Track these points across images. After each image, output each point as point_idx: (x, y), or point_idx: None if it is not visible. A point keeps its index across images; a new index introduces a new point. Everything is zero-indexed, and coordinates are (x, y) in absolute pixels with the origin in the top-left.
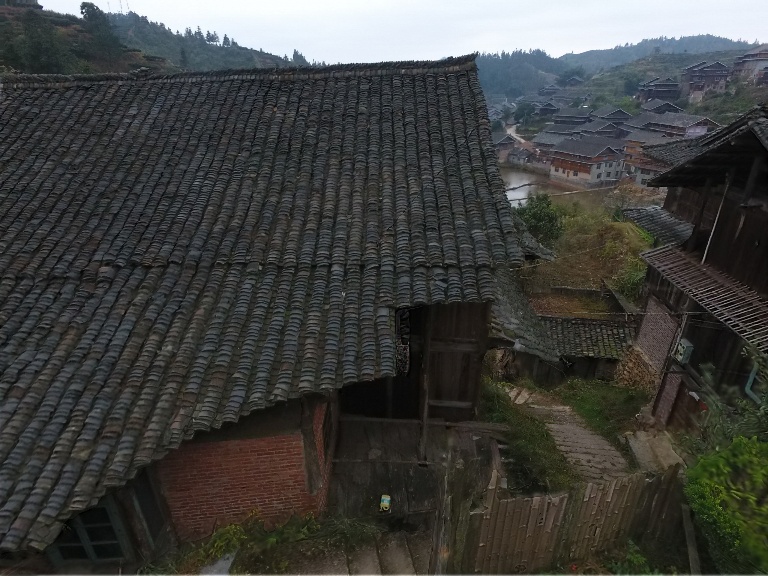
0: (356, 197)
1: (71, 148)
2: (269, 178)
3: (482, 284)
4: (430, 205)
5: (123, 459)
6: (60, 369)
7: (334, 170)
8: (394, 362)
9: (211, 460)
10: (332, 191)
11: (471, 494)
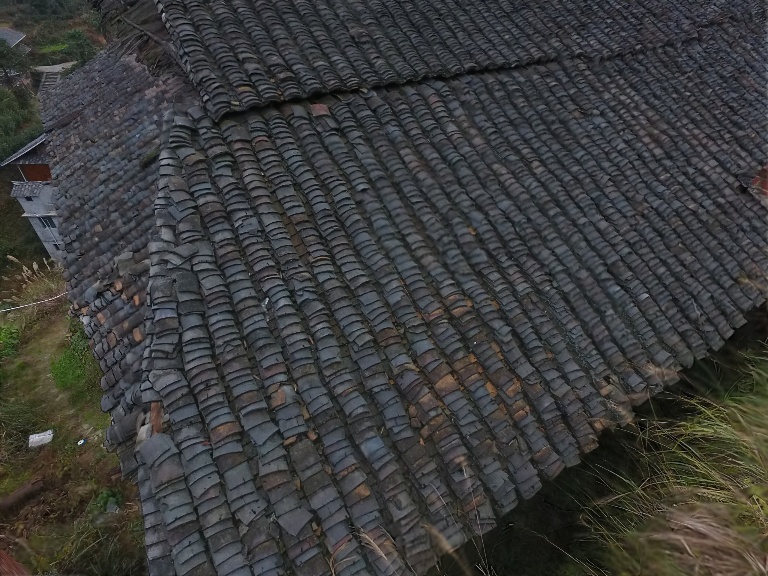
0: None
1: None
2: None
3: None
4: None
5: None
6: None
7: None
8: None
9: None
10: None
11: None
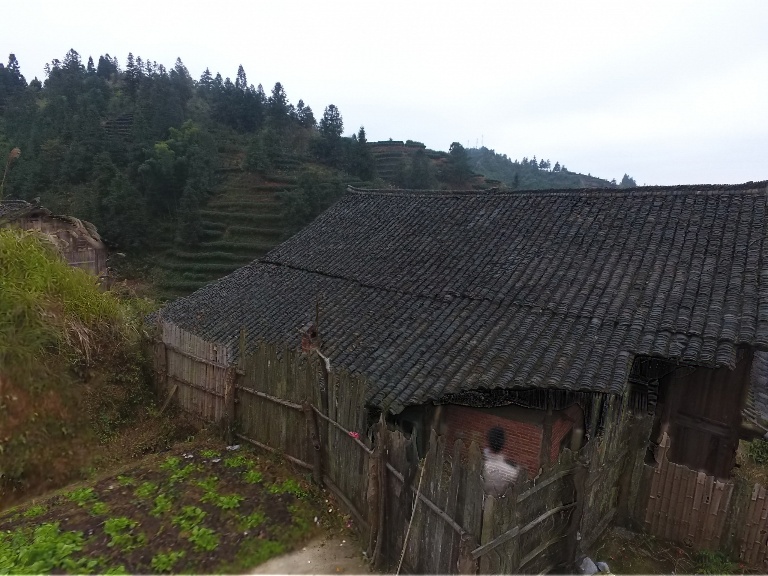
0: (626, 279)
1: (443, 231)
2: (562, 259)
3: (720, 353)
4: (690, 291)
5: (439, 387)
6: (416, 339)
7: (613, 259)
8: (623, 387)
9: (478, 426)
10: (607, 273)
11: (645, 445)
